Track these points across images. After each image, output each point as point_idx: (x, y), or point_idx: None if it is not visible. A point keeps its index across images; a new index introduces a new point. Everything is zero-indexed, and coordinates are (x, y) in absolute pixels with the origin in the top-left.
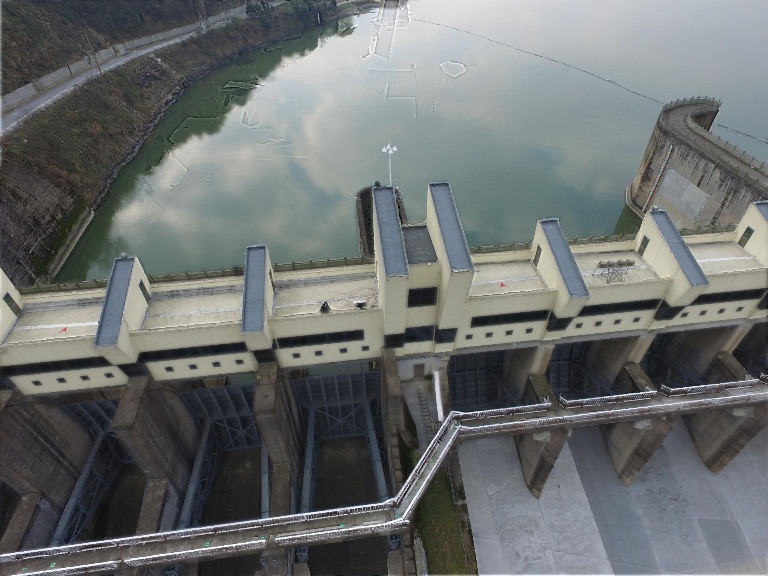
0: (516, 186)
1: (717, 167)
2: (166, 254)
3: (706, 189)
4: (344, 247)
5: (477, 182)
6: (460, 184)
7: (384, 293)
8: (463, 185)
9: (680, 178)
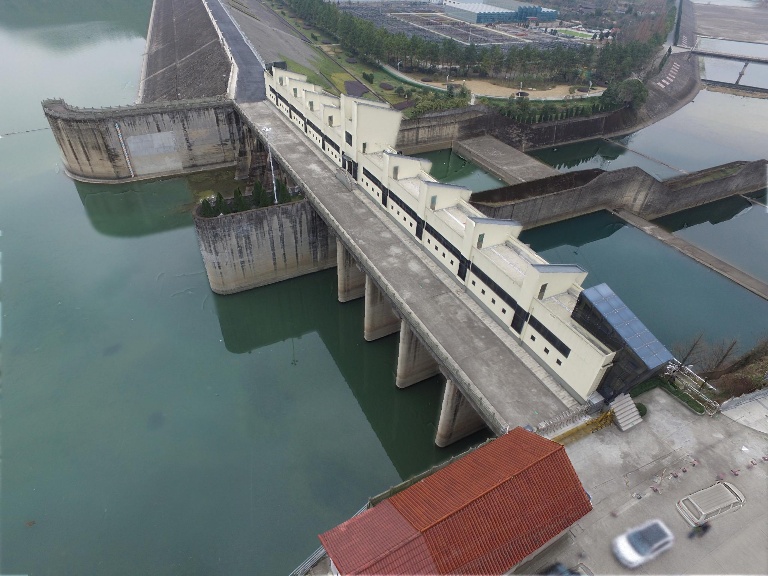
0: (60, 232)
1: (163, 114)
2: (189, 498)
3: (167, 129)
4: (172, 322)
5: (41, 255)
6: (41, 266)
7: (395, 129)
8: (44, 264)
9: (142, 137)
